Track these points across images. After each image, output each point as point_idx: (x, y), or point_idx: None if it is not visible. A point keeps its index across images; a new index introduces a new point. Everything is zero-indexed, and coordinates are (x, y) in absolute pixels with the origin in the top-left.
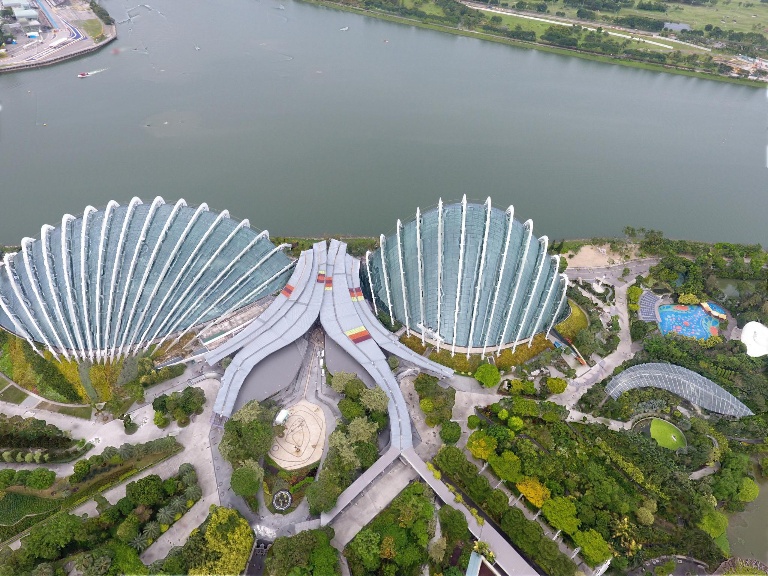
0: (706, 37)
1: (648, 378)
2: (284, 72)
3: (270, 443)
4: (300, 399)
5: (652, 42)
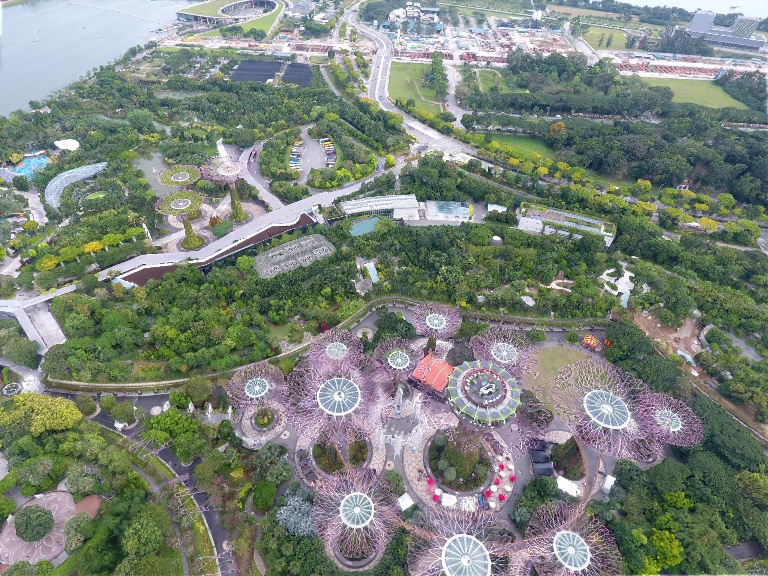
0: None
1: (58, 188)
2: None
3: None
4: None
5: None
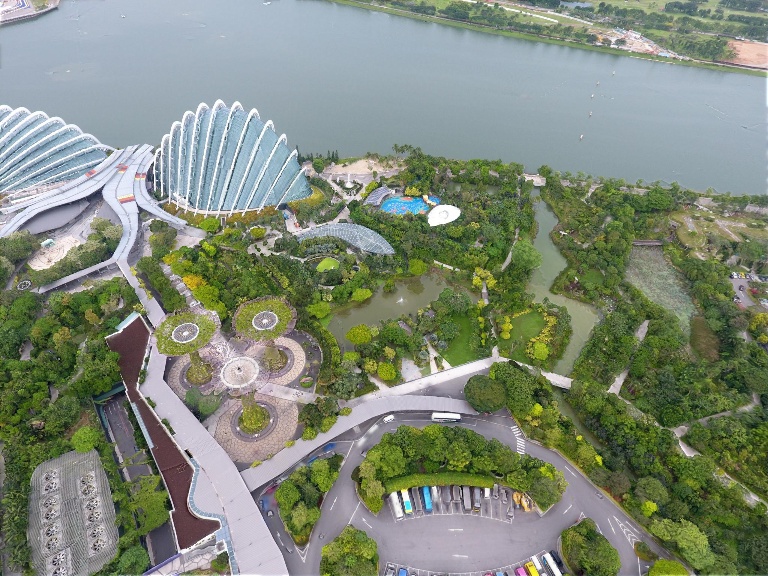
0: (595, 13)
1: (331, 231)
2: (191, 36)
3: (27, 253)
4: (68, 236)
5: (542, 17)
